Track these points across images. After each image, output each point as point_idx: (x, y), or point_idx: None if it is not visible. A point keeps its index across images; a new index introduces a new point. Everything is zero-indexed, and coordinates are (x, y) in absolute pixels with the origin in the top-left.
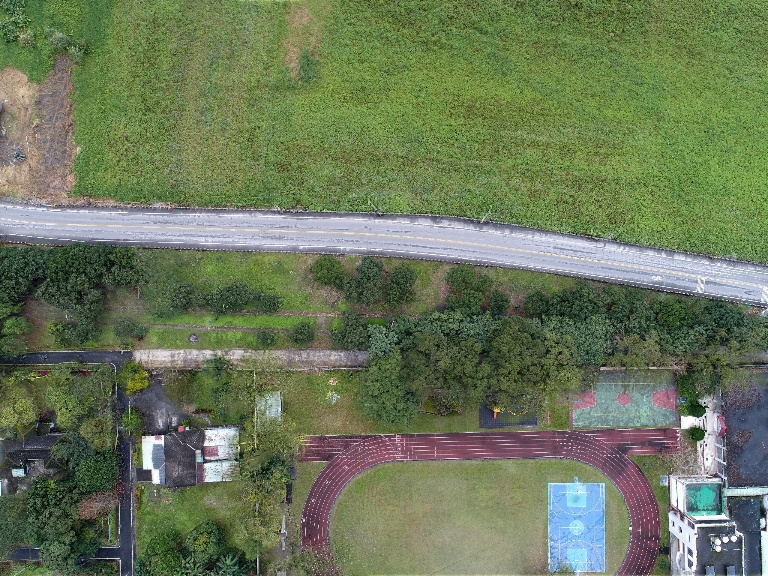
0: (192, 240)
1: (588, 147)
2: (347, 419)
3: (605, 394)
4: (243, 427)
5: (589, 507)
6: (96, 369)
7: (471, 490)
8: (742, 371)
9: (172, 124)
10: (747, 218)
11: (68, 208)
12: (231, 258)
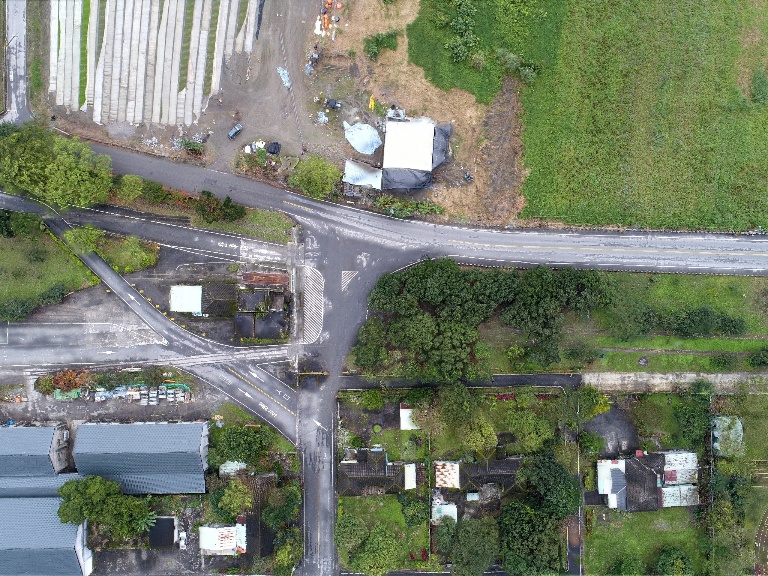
0: (644, 263)
1: None
2: None
3: None
4: (694, 451)
5: None
6: (547, 392)
7: None
8: None
9: (623, 145)
10: None
11: (517, 230)
12: (682, 281)
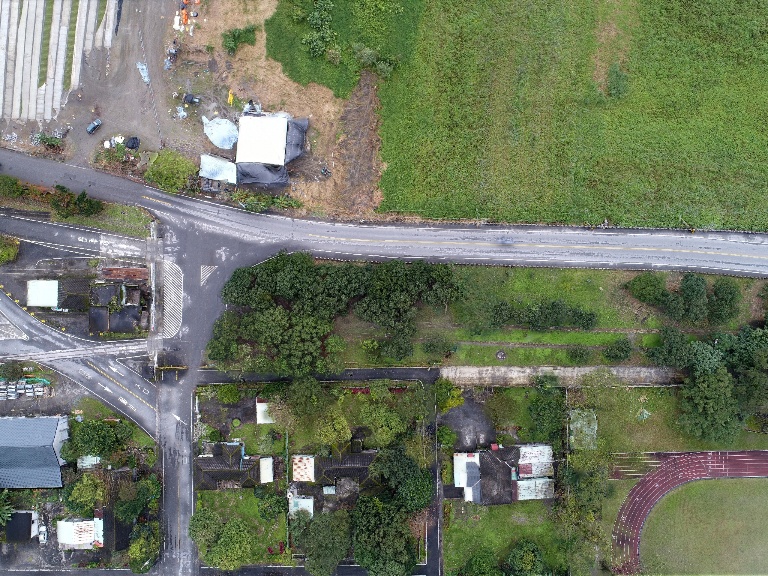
0: (501, 256)
1: None
2: (658, 436)
3: None
4: (552, 444)
5: None
6: (405, 386)
7: None
8: None
9: (480, 139)
10: None
11: (375, 224)
12: (539, 274)
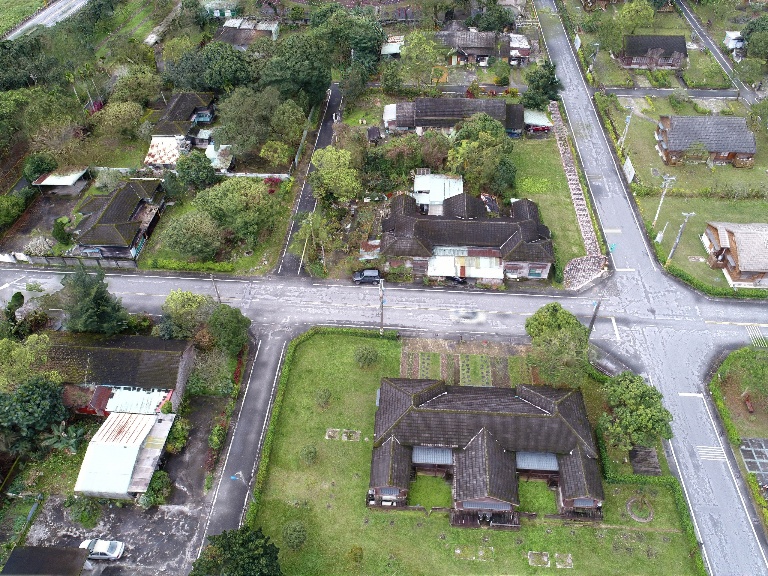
0: None
1: None
2: None
3: None
4: None
5: None
6: None
7: None
8: None
9: None
10: None
11: None
12: None
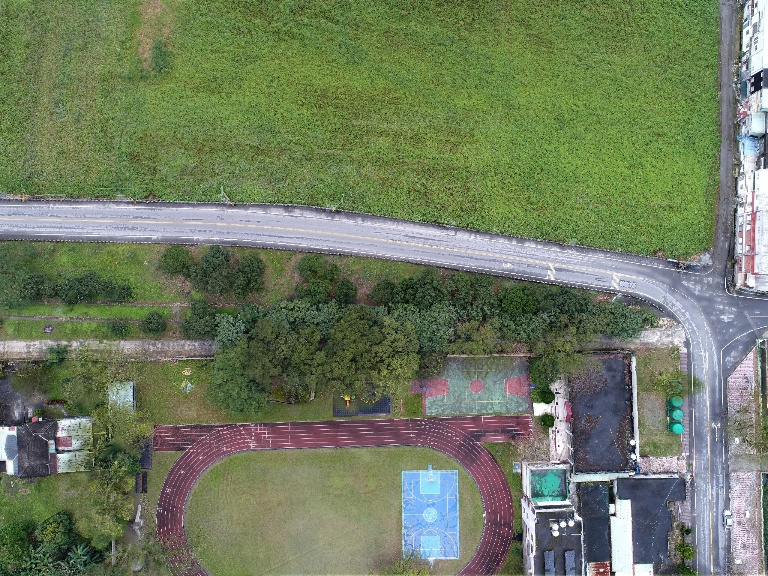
0: (46, 232)
1: (439, 135)
2: (201, 409)
3: (458, 381)
4: (99, 418)
5: (442, 494)
6: None
7: (325, 478)
8: (589, 357)
9: (26, 116)
10: (597, 205)
11: None
12: (85, 249)
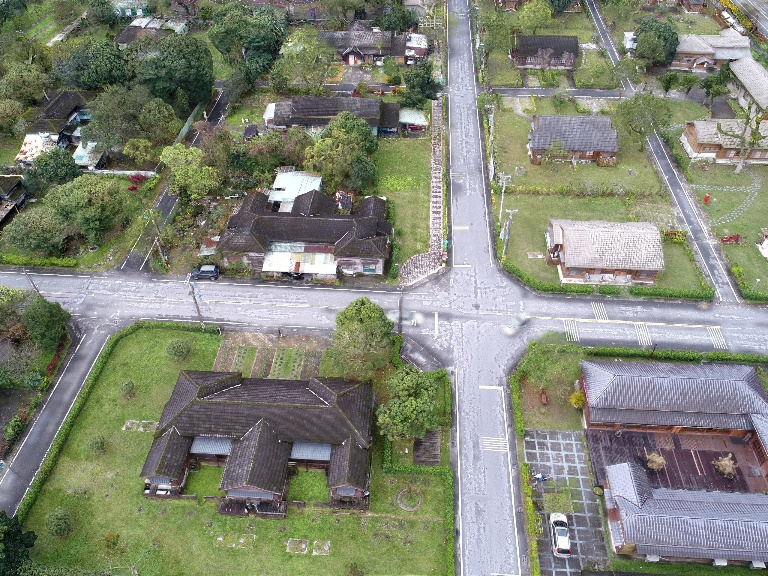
0: None
1: None
2: None
3: None
4: None
5: None
6: None
7: None
8: None
9: None
10: None
11: None
12: None
